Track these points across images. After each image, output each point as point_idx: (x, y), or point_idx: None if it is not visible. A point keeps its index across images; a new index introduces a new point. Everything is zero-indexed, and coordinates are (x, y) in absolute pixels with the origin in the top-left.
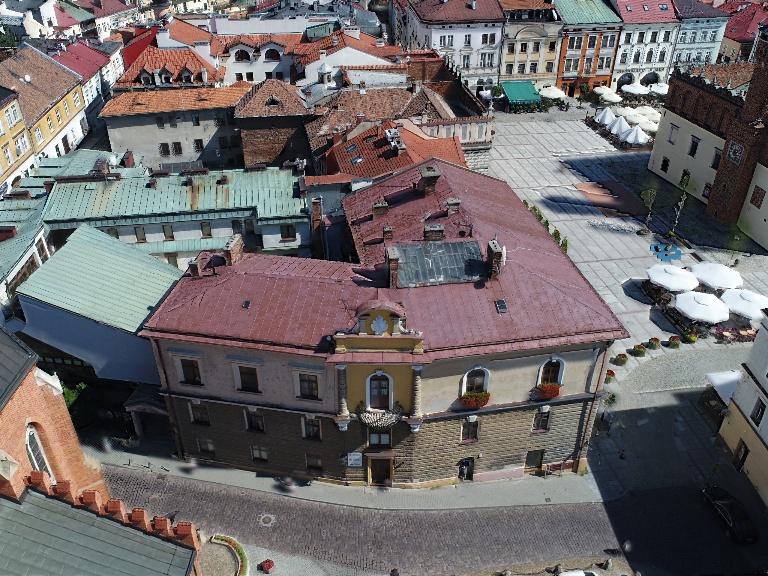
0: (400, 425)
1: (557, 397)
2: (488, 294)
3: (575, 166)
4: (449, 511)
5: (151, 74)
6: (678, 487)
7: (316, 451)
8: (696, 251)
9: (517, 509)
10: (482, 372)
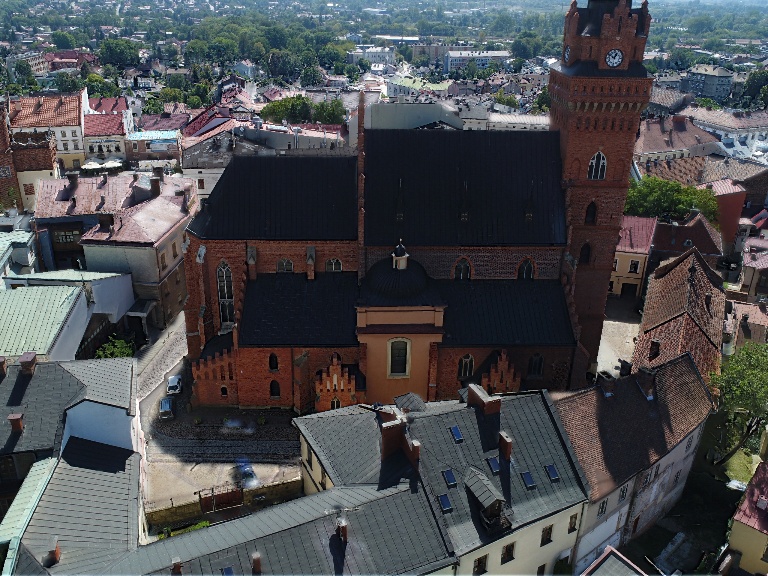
0: None
1: None
2: (171, 185)
3: None
4: None
5: None
6: None
7: None
8: None
9: None
10: None
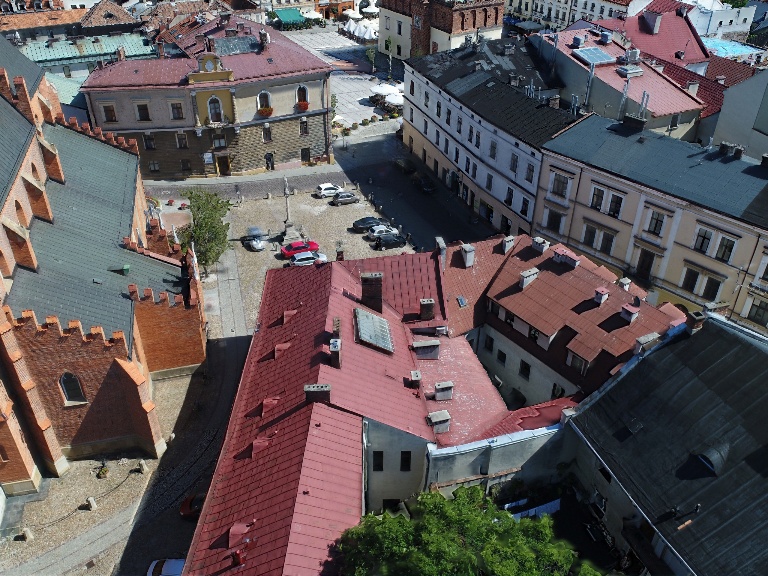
0: (229, 131)
1: (308, 111)
2: (263, 57)
3: (331, 54)
4: (264, 181)
5: (9, 3)
6: (382, 163)
7: (186, 156)
8: None
9: (299, 177)
10: (267, 95)
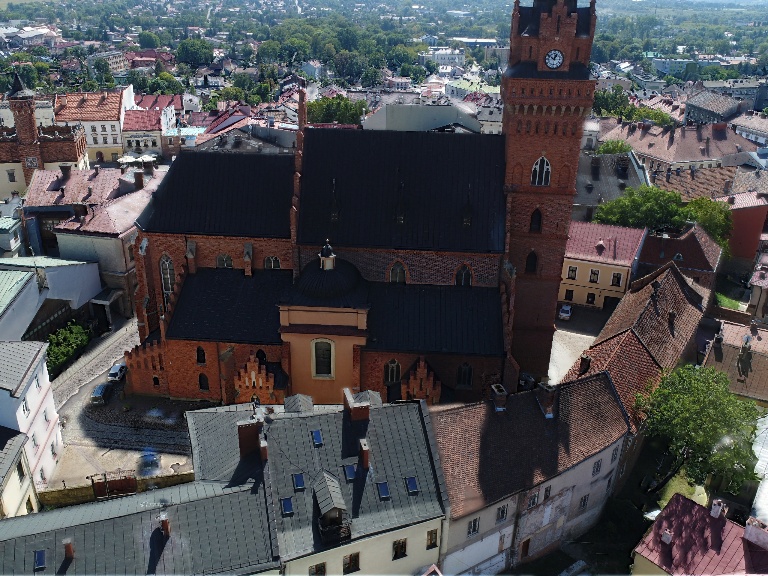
0: None
1: None
2: (160, 179)
3: None
4: None
5: None
6: None
7: None
8: None
9: None
10: None
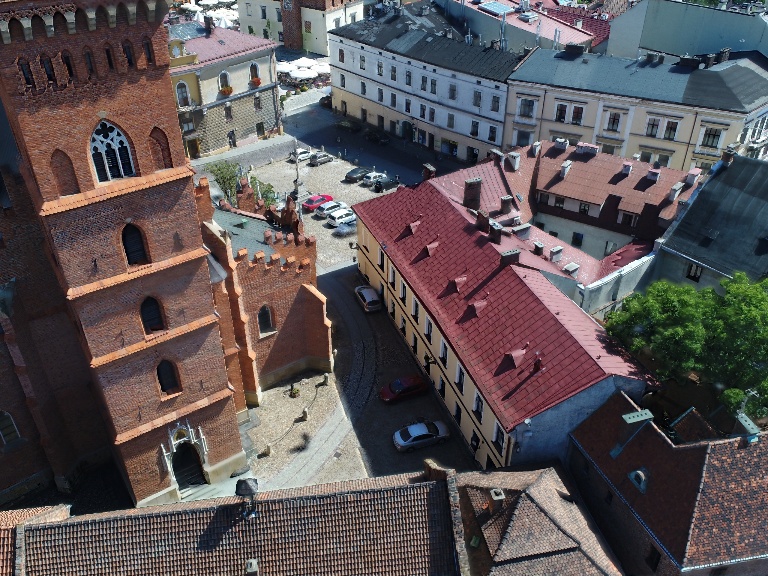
0: (197, 113)
1: (260, 87)
2: (213, 39)
3: None
4: (233, 157)
5: None
6: (325, 128)
7: None
8: (289, 63)
9: (263, 150)
10: (225, 75)
